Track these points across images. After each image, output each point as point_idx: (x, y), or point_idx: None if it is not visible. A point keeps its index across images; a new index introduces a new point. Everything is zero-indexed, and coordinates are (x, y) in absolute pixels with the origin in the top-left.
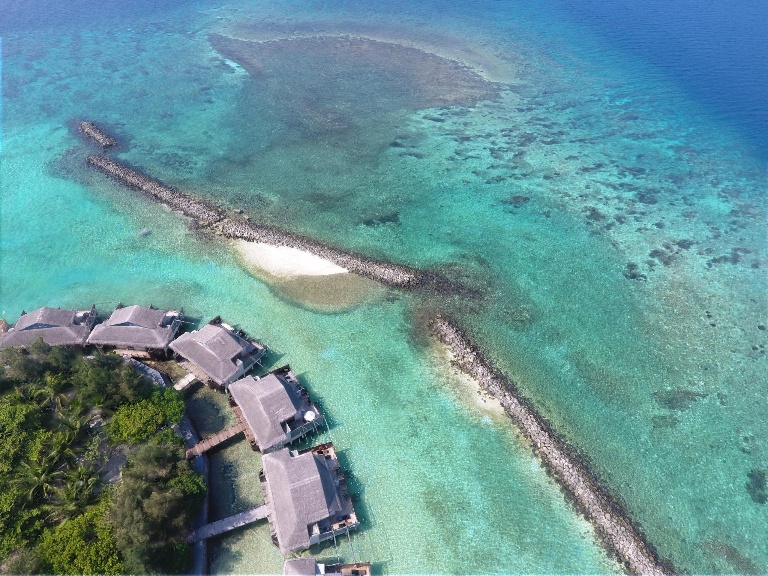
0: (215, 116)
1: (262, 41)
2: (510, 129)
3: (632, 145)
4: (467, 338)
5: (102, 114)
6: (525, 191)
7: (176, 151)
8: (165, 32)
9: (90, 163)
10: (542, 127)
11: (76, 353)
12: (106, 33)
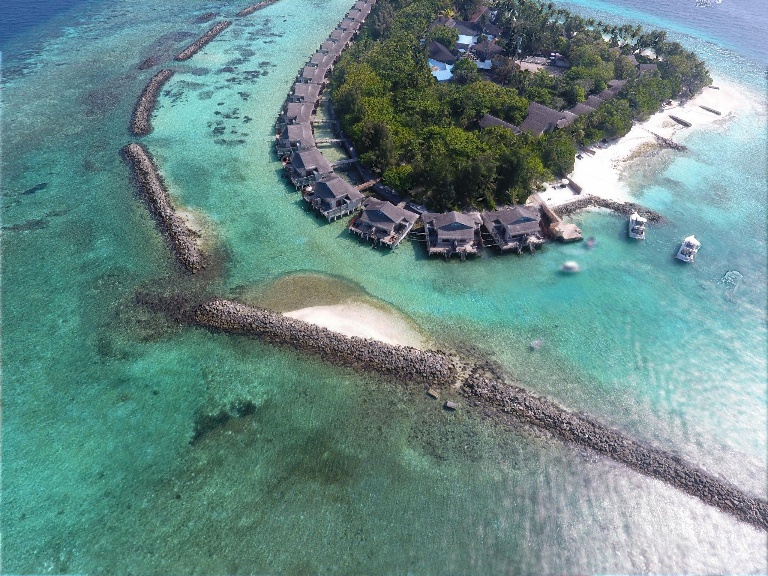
0: None
1: None
2: None
3: None
4: (177, 255)
5: None
6: None
7: None
8: None
9: None
10: None
11: (464, 182)
12: None
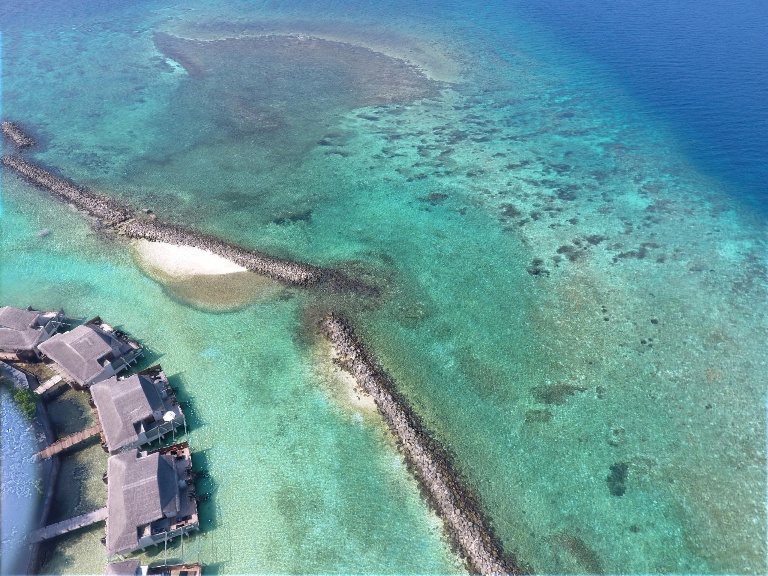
0: (144, 115)
1: (208, 40)
2: (443, 127)
3: (562, 142)
4: (355, 335)
5: (27, 114)
6: (445, 188)
7: (96, 151)
8: (110, 31)
9: (2, 163)
10: (476, 125)
11: None
12: (49, 32)
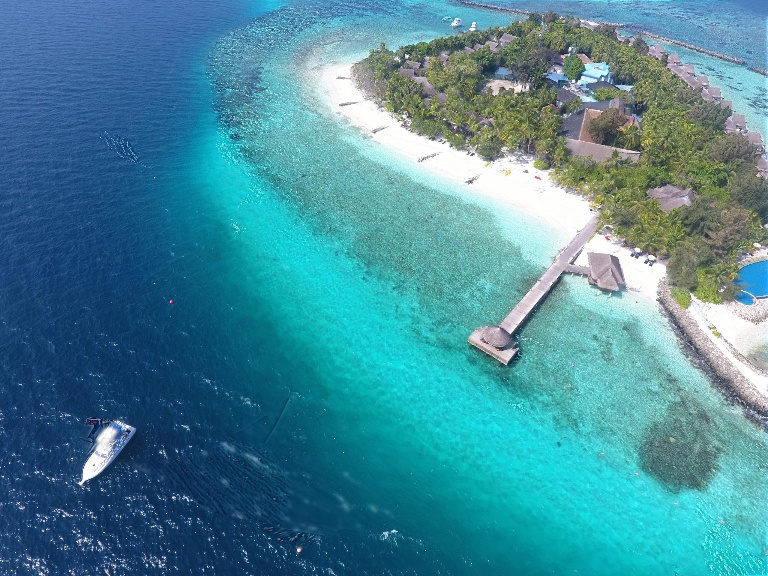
0: None
1: None
2: None
3: (686, 3)
4: None
5: None
6: (648, 12)
7: None
8: None
9: (465, 3)
10: None
11: None
12: None
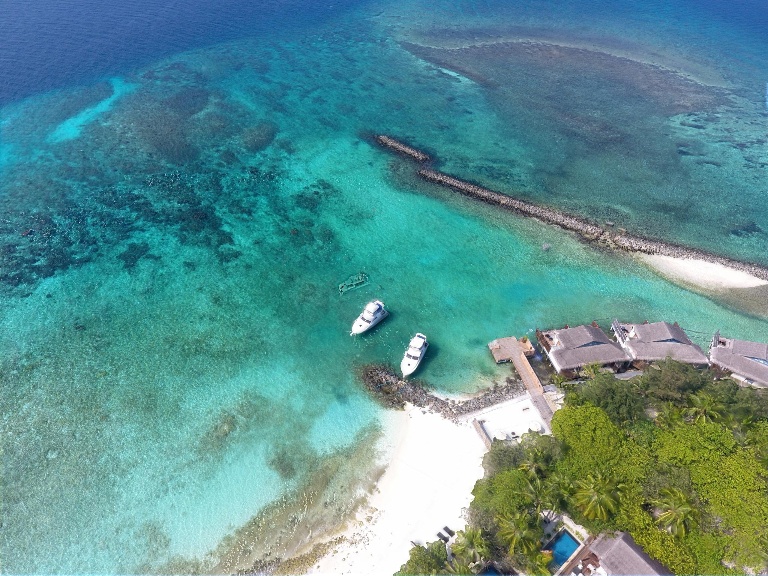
0: (488, 127)
1: (455, 48)
2: None
3: None
4: None
5: (383, 127)
6: None
7: (489, 164)
8: (356, 41)
9: (426, 178)
10: None
11: None
12: (302, 43)
